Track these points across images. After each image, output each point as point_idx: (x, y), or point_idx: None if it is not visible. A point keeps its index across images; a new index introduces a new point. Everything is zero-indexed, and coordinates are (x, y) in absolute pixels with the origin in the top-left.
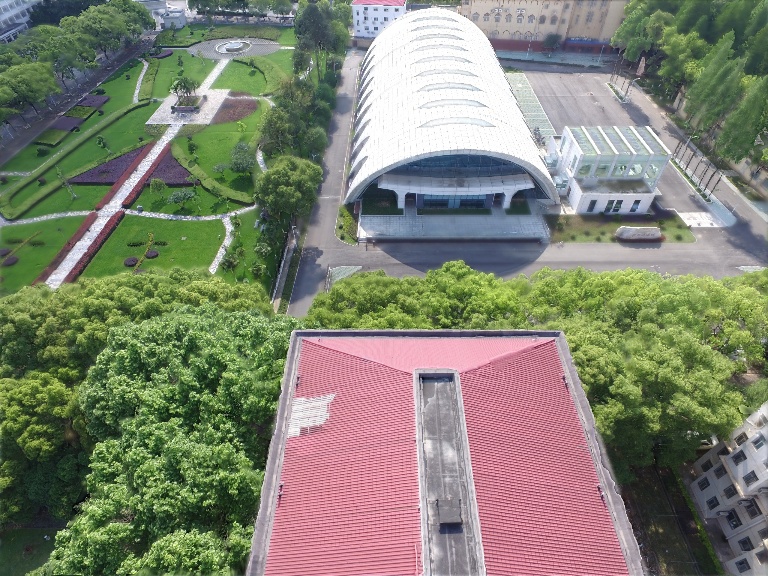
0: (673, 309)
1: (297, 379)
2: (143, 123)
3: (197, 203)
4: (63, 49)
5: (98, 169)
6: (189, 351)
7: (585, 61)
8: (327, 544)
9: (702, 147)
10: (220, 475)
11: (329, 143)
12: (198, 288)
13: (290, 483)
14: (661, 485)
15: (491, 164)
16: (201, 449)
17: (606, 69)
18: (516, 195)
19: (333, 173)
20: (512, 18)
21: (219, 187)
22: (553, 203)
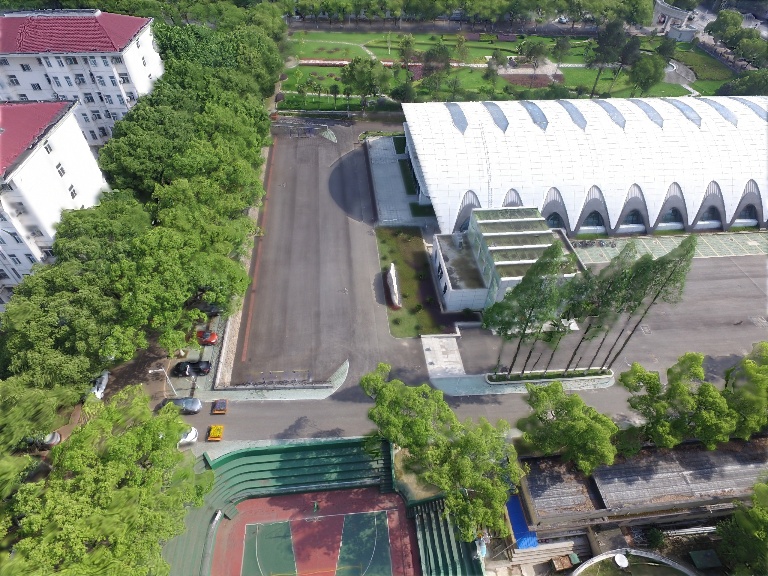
0: None
1: None
2: None
3: None
4: None
5: None
6: None
7: None
8: None
9: None
10: None
11: None
12: None
13: None
14: None
15: None
16: None
17: None
18: None
19: None
20: None
21: None
22: None
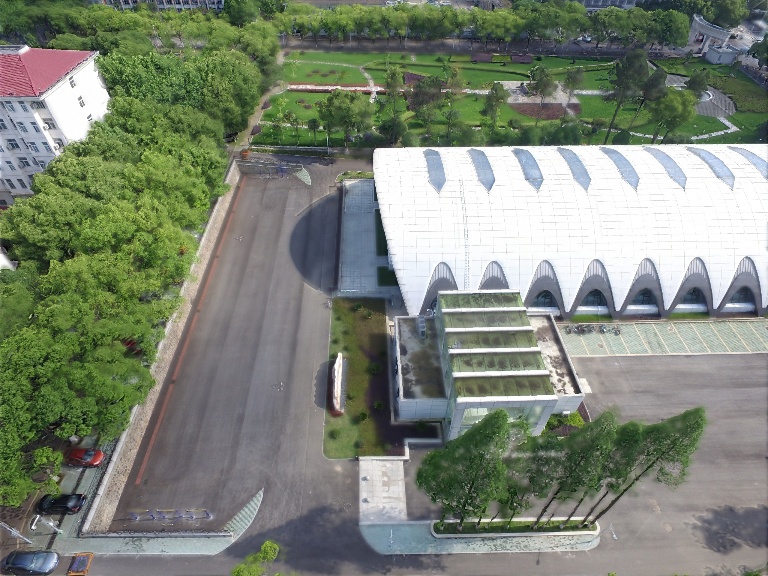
0: None
1: None
2: None
3: None
4: (546, 18)
5: (421, 77)
6: None
7: None
8: None
9: None
10: None
11: None
12: None
13: None
14: None
15: None
16: None
17: None
18: None
19: None
20: None
21: None
22: None
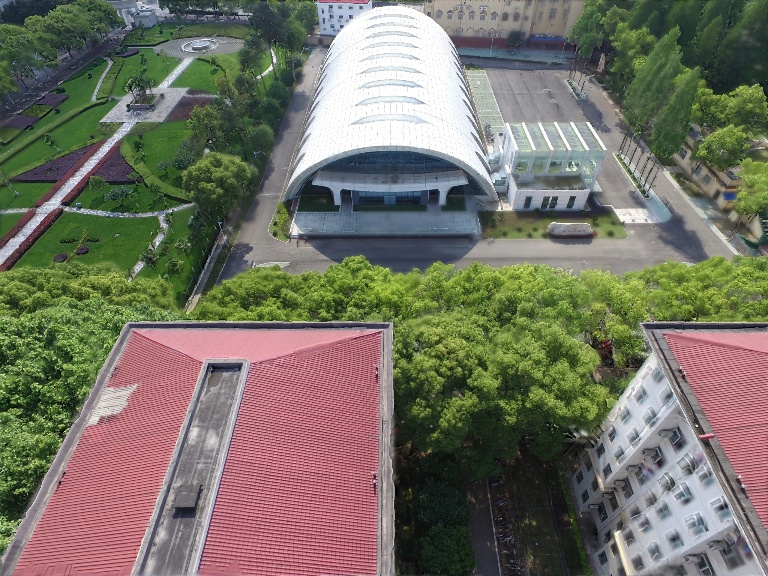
0: (553, 303)
1: (114, 369)
2: (97, 121)
3: (134, 200)
4: (21, 48)
5: (44, 167)
6: (49, 344)
7: (548, 58)
8: (80, 529)
9: (651, 143)
10: (34, 464)
11: (279, 140)
12: (91, 283)
13: (72, 470)
14: (543, 479)
15: (425, 160)
16: (24, 439)
17: (568, 66)
18: (454, 192)
19: (278, 170)
20: (475, 15)
21: (159, 184)
22: (491, 199)
